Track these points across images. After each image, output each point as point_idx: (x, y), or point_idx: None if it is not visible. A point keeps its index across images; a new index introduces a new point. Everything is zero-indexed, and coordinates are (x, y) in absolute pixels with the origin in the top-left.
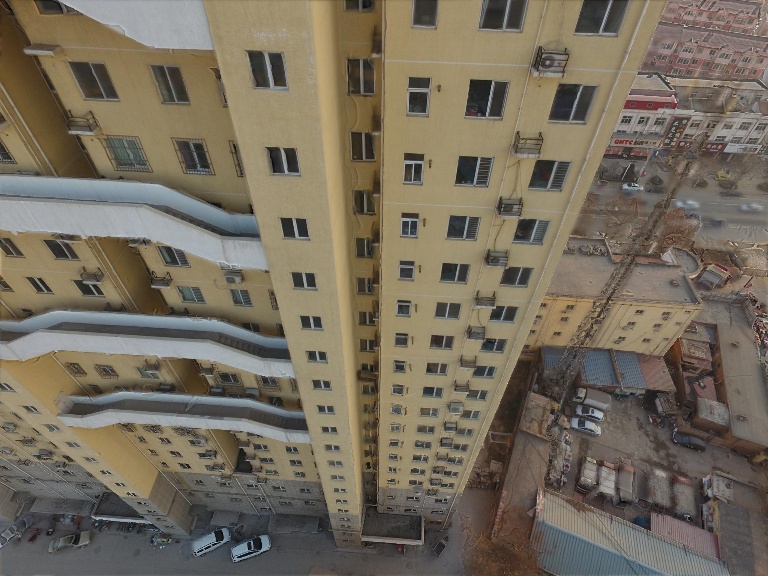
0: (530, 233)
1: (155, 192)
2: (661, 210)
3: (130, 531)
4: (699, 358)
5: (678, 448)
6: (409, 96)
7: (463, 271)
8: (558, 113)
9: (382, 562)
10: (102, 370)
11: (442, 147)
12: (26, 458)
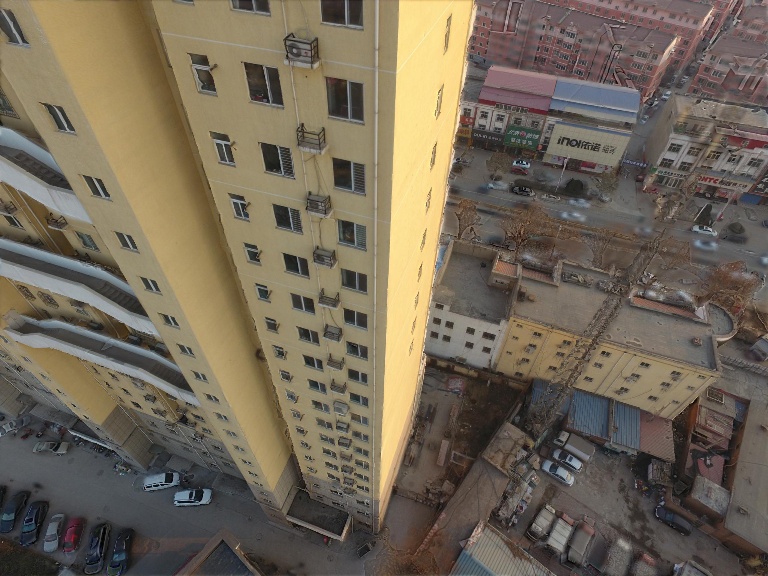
0: (353, 236)
1: (10, 136)
2: (646, 253)
3: (100, 452)
4: (715, 432)
5: (659, 524)
6: (197, 73)
7: (304, 265)
8: (339, 109)
9: (306, 547)
10: (47, 298)
11: (240, 130)
12: (19, 365)
